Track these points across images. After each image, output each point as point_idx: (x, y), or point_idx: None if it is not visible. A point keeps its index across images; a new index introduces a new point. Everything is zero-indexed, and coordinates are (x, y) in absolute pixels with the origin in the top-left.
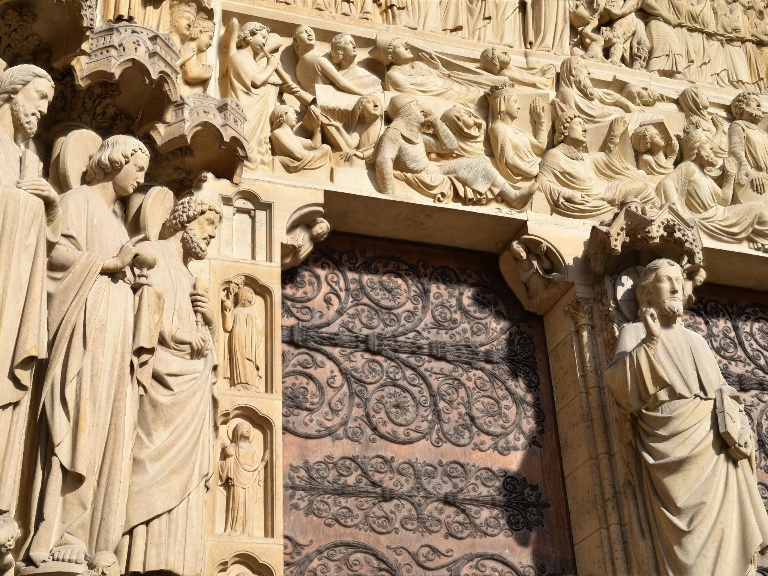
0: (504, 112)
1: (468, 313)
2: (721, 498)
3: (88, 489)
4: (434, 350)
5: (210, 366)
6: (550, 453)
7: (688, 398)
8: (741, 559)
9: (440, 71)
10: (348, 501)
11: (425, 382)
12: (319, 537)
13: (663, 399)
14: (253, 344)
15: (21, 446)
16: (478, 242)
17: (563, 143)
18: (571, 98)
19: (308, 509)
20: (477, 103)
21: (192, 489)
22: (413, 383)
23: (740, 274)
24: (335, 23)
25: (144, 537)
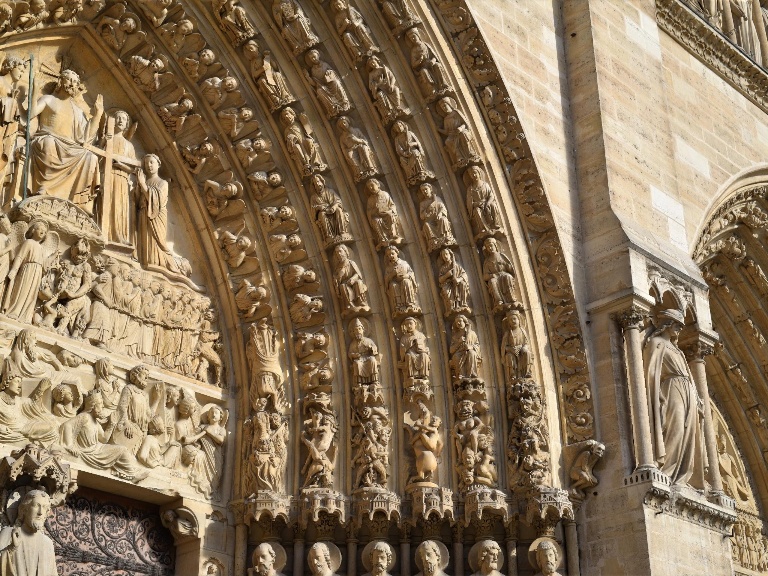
0: None
1: None
2: None
3: None
4: None
5: None
6: None
7: None
8: None
9: None
10: None
11: None
12: None
13: None
14: None
15: None
16: None
17: (4, 391)
18: (19, 359)
19: None
20: None
21: None
22: None
23: (104, 485)
24: None
25: None
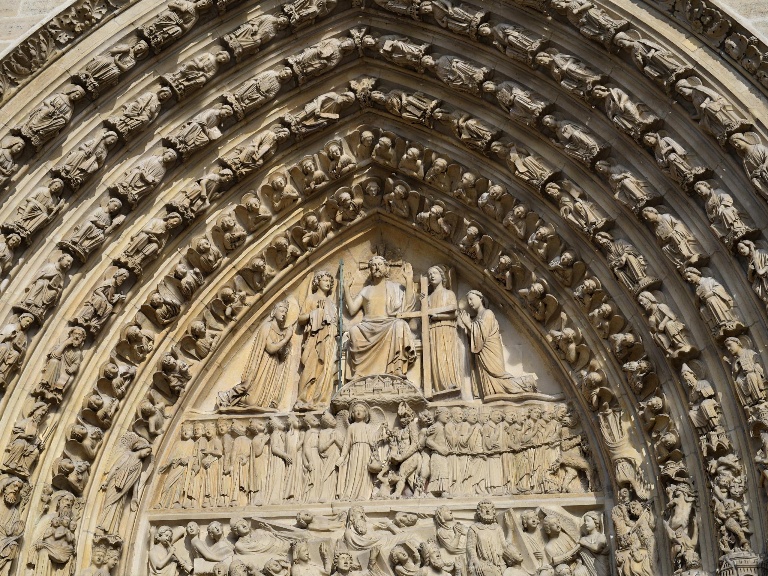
0: (298, 559)
1: None
2: None
3: None
4: None
5: None
6: None
7: None
8: None
9: (272, 532)
10: None
11: None
12: None
13: None
14: None
15: None
16: None
17: (337, 571)
18: (349, 536)
19: None
20: (289, 552)
21: None
22: None
23: None
24: (213, 513)
25: None
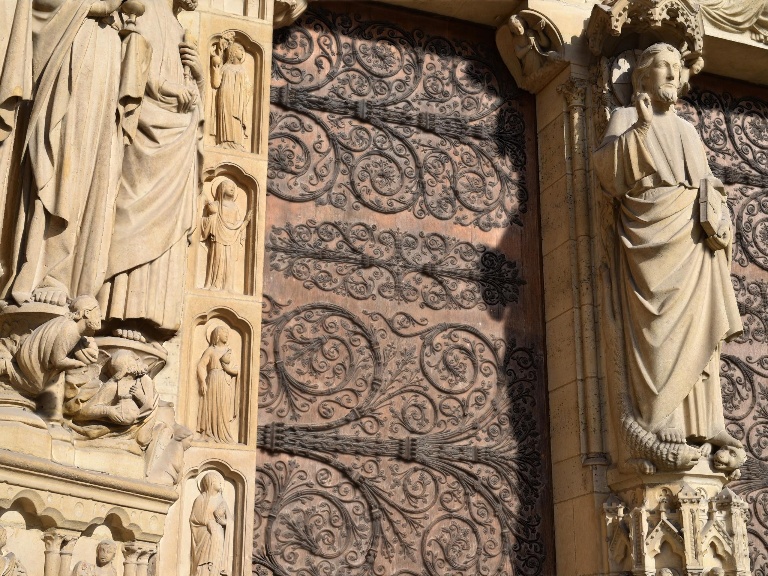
0: None
1: (460, 86)
2: (694, 286)
3: (71, 234)
4: (423, 122)
5: (197, 121)
6: (530, 232)
7: (673, 186)
8: (707, 345)
9: None
10: (328, 265)
11: (412, 153)
12: (297, 298)
13: (648, 185)
14: (241, 102)
15: (4, 187)
16: (476, 14)
17: None
18: None
19: (288, 271)
20: None
21: (174, 242)
22: (400, 153)
23: (738, 65)
24: None
25: (125, 285)
